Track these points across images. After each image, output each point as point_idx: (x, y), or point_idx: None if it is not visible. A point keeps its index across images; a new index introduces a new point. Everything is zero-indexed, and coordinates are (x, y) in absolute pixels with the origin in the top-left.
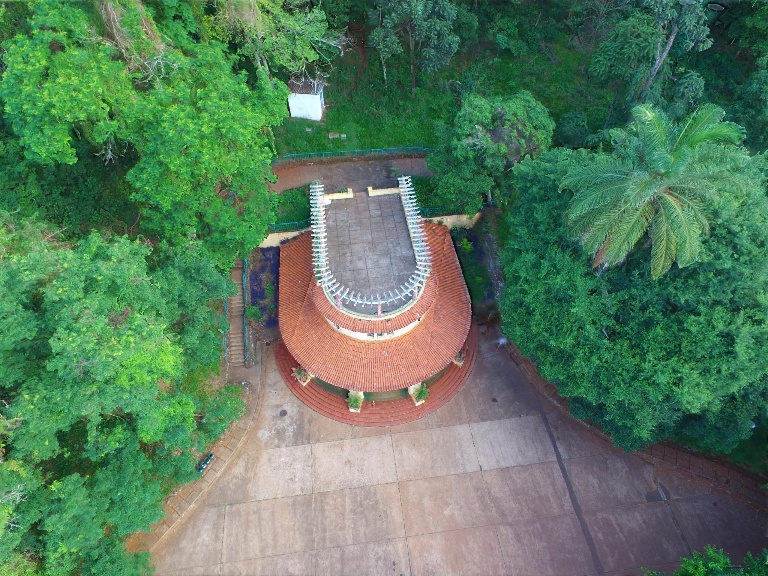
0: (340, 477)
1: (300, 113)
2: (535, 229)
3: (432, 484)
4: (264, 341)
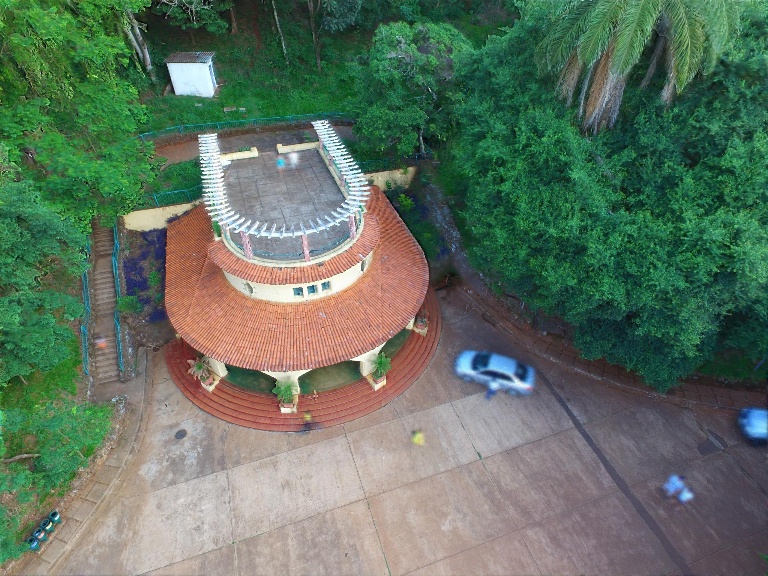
0: (276, 509)
1: (186, 89)
2: (496, 107)
3: (416, 491)
4: (150, 346)
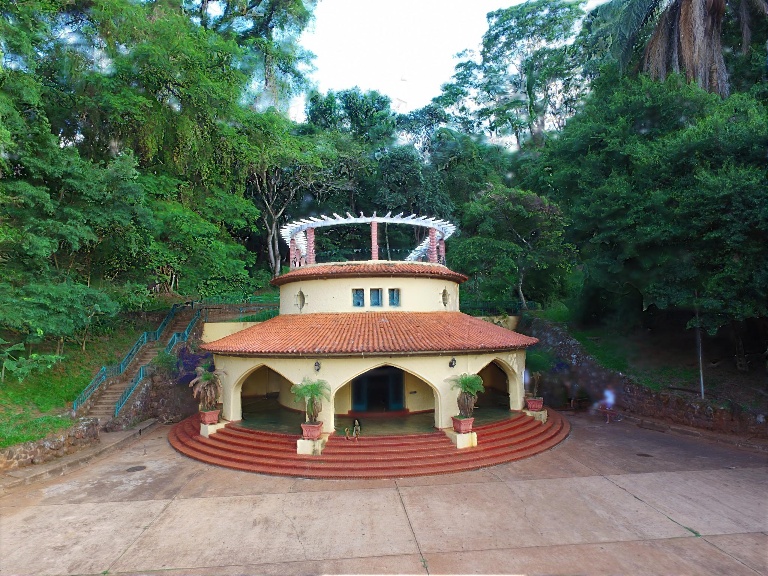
0: (224, 543)
1: None
2: None
3: (543, 558)
4: (163, 420)
